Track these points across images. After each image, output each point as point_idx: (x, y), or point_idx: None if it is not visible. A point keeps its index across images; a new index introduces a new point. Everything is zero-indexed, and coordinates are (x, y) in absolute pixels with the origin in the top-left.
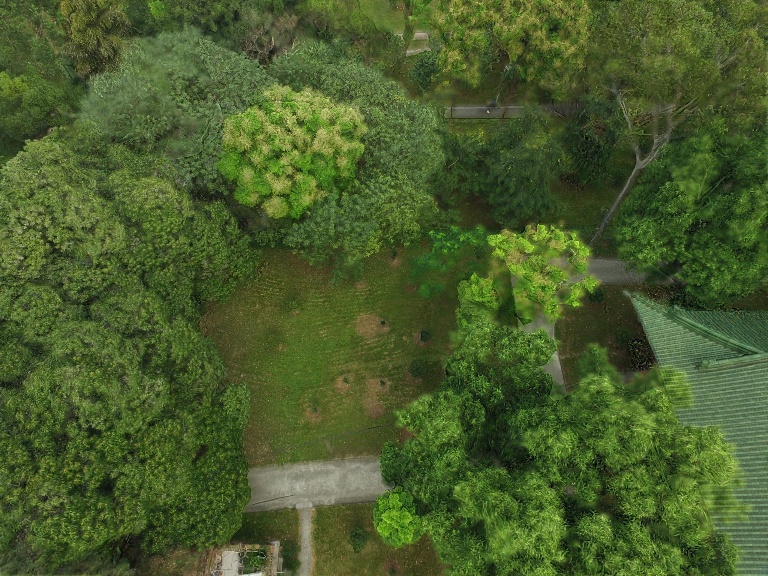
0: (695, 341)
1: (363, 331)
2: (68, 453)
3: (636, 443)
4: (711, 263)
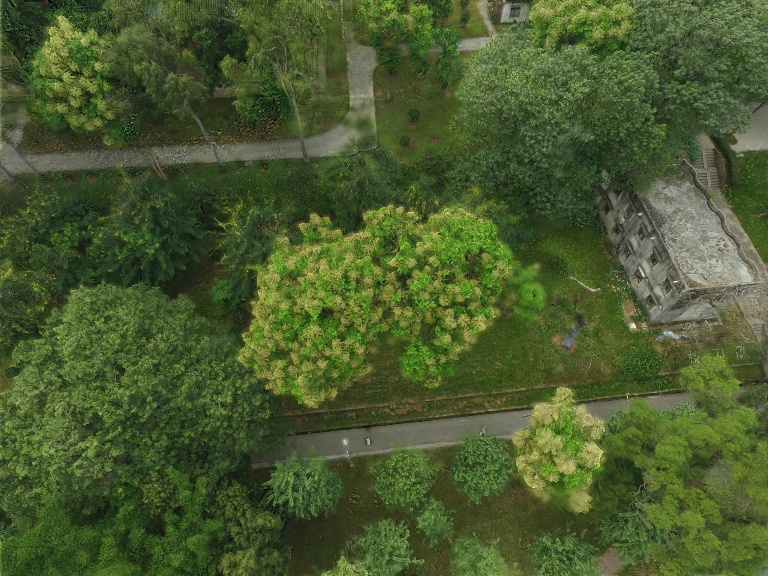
0: None
1: None
2: None
3: None
4: (279, 5)
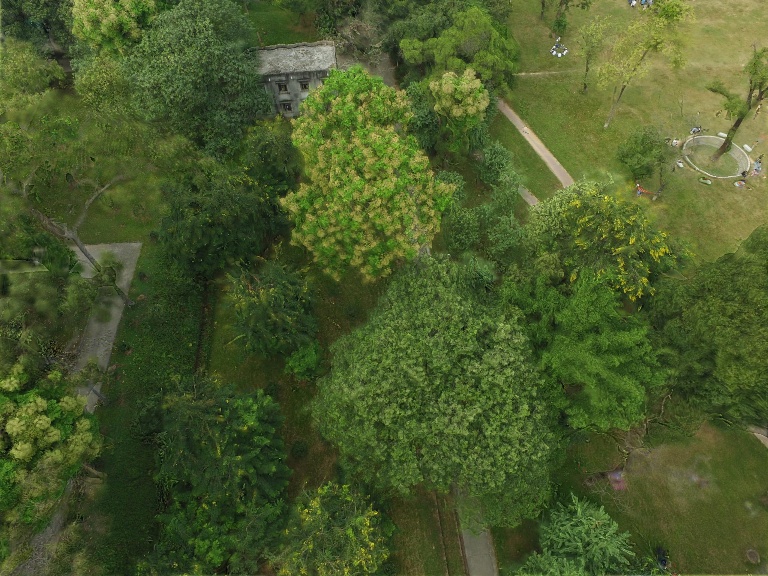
0: None
1: (95, 153)
2: None
3: None
4: None
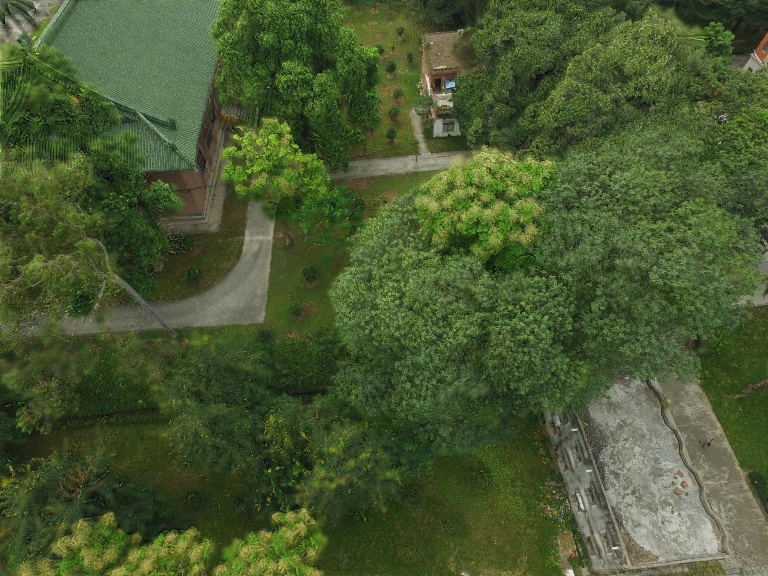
0: (168, 138)
1: None
2: (519, 6)
3: (261, 5)
4: None
